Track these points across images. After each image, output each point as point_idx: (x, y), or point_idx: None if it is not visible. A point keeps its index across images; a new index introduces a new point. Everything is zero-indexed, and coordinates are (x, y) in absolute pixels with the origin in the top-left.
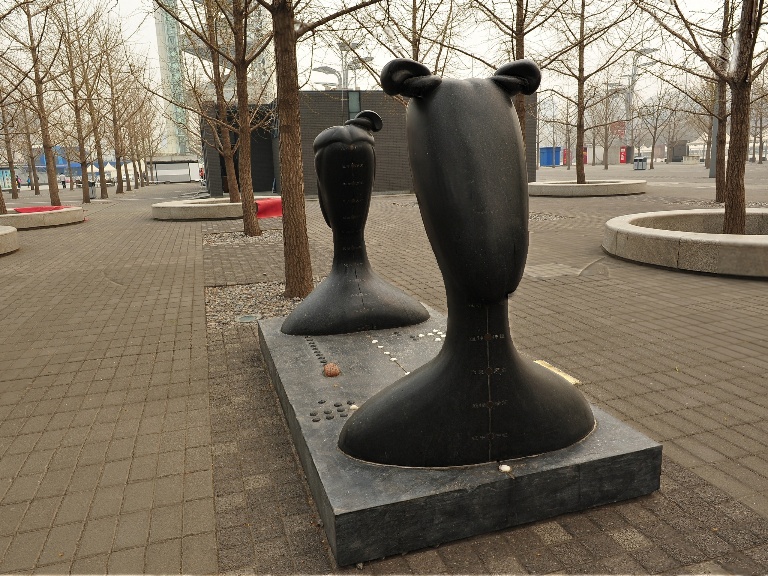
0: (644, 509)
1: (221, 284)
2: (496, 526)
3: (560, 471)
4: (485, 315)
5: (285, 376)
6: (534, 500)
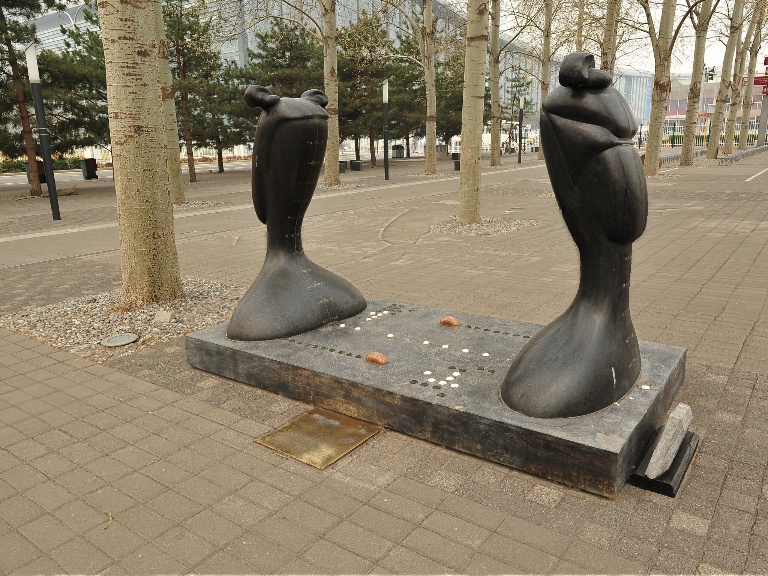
0: None
1: None
2: None
3: None
4: None
5: (474, 315)
6: None
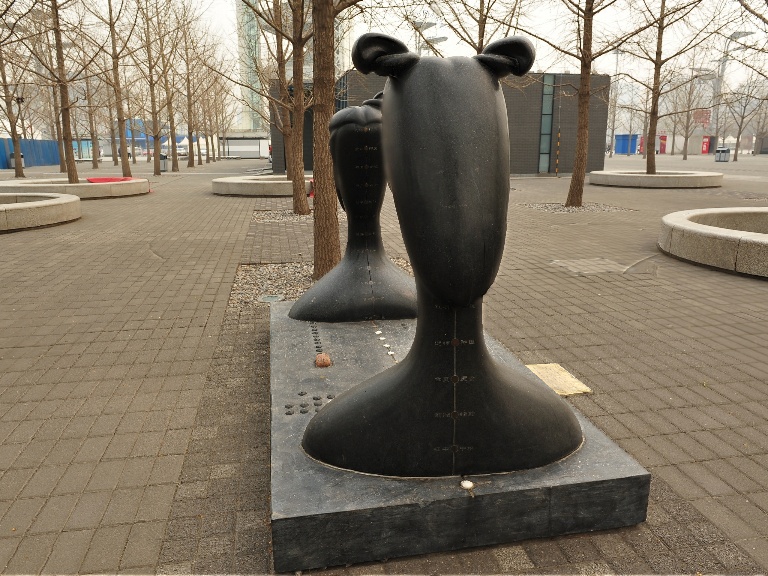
0: (623, 542)
1: (255, 262)
2: (452, 545)
3: (528, 493)
4: (453, 318)
5: (276, 363)
6: (496, 521)
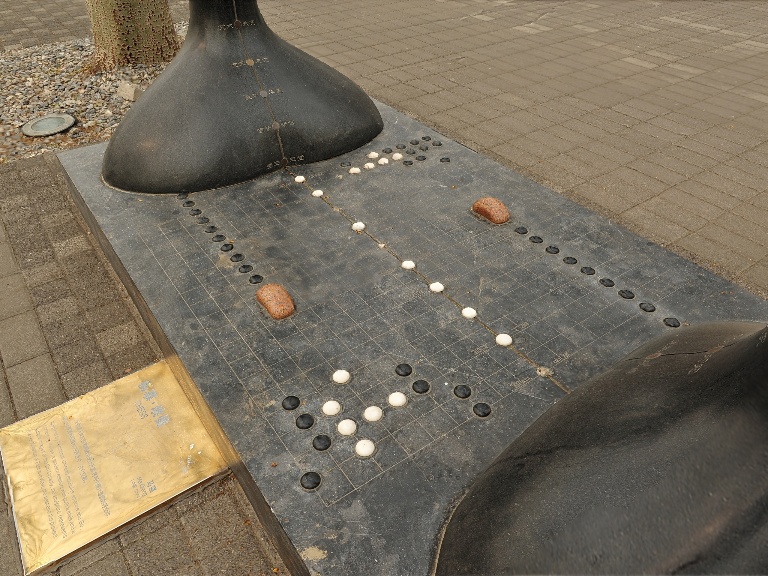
0: None
1: None
2: None
3: None
4: None
5: (554, 196)
6: None
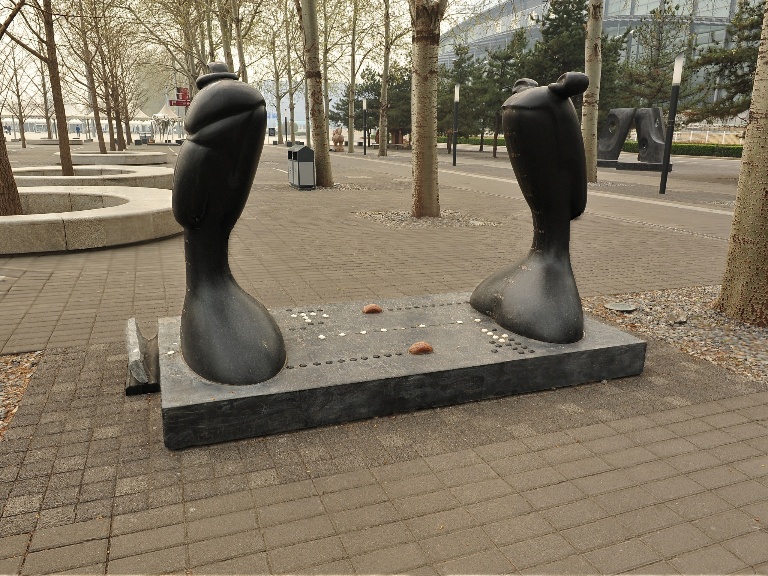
0: None
1: None
2: None
3: None
4: None
5: (434, 369)
6: None
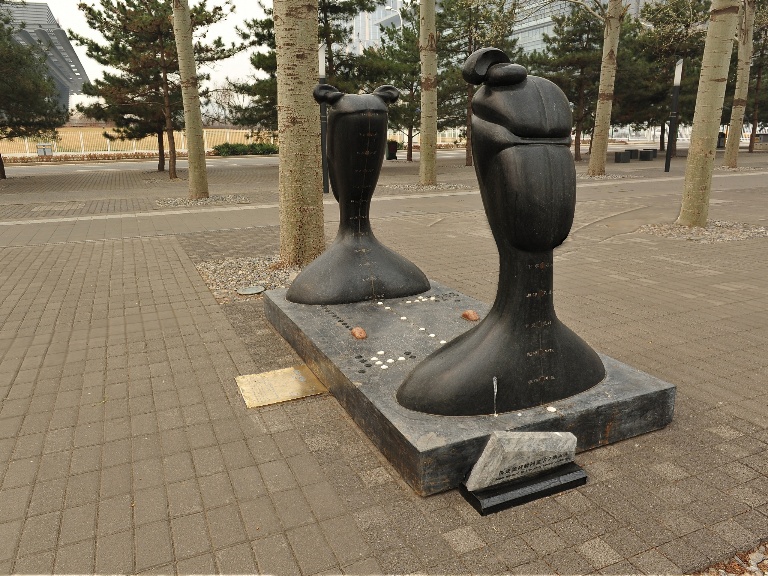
0: None
1: None
2: None
3: None
4: None
5: None
6: None
